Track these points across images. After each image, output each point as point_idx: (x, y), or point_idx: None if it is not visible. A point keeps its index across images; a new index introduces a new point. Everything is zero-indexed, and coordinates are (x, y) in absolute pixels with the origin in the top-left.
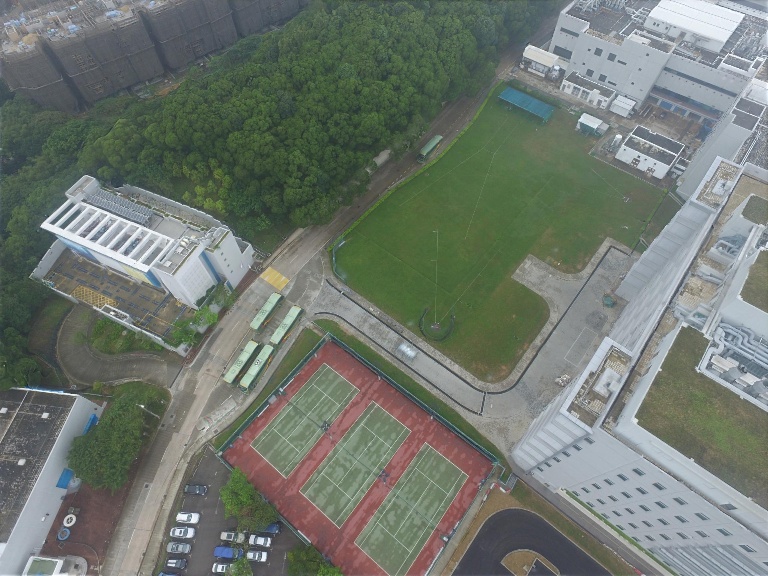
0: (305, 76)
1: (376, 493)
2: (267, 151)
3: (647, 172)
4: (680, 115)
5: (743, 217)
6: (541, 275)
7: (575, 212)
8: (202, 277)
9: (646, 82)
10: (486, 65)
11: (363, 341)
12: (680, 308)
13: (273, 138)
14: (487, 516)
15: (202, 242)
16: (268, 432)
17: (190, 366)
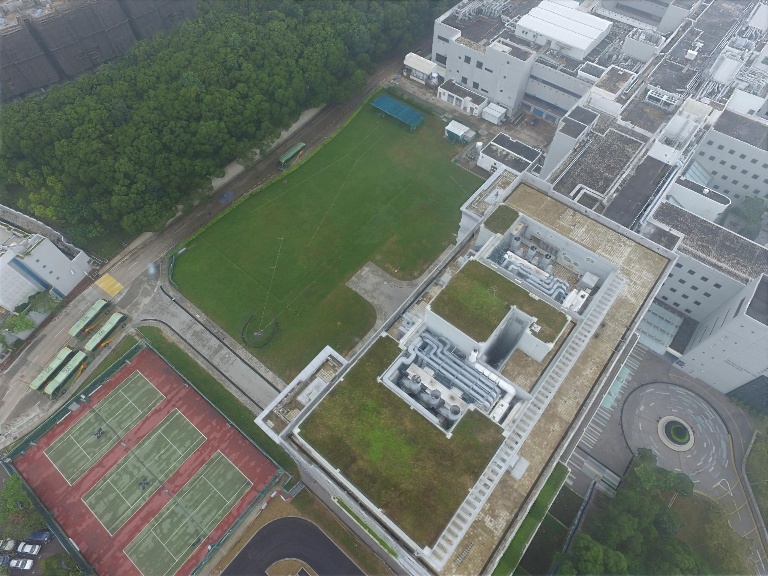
0: (148, 84)
1: (157, 501)
2: (93, 159)
3: None
4: (551, 122)
5: (483, 226)
6: (376, 282)
7: (424, 219)
8: (18, 284)
9: (512, 90)
10: (355, 73)
11: (183, 348)
12: (406, 317)
13: (101, 146)
14: (262, 524)
15: (11, 249)
16: (64, 439)
17: (5, 372)
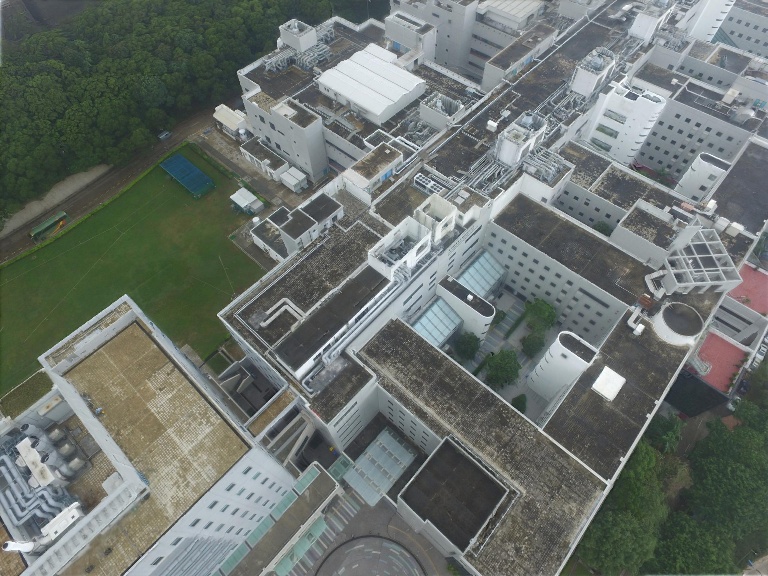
0: None
1: None
2: None
3: (278, 262)
4: None
5: None
6: None
7: (168, 311)
8: None
9: (305, 156)
10: None
11: None
12: None
13: None
14: None
15: None
16: None
17: None
